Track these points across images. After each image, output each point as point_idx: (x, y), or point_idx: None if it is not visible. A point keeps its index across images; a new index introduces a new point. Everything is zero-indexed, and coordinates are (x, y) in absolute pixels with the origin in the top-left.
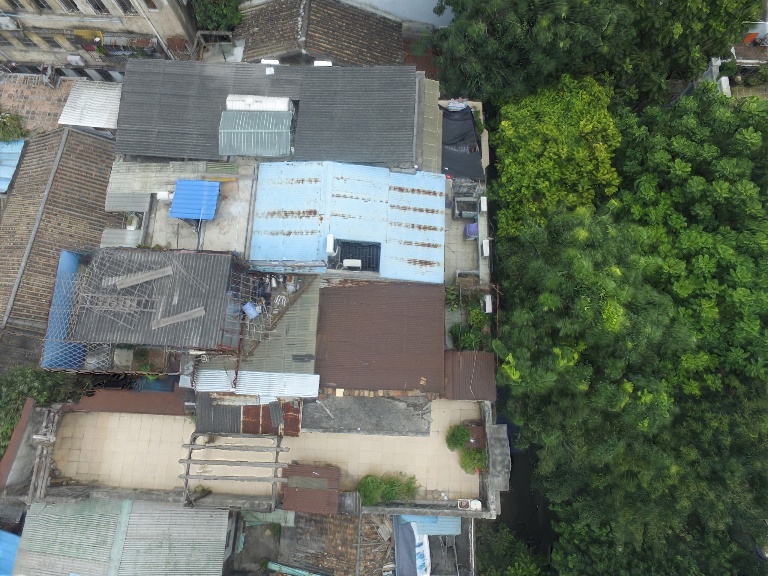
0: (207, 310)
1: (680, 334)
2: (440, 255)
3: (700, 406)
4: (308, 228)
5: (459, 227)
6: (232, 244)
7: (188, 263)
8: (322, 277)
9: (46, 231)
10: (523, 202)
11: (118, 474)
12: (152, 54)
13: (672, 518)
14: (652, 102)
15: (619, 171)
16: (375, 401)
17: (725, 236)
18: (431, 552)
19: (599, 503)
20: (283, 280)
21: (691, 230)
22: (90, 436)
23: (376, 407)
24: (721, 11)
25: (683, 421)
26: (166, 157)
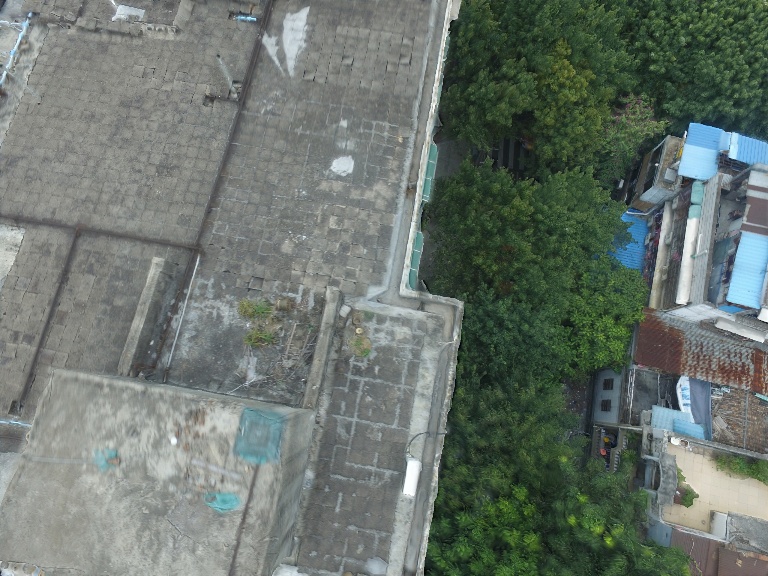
0: None
1: None
2: None
3: None
4: None
5: None
6: None
7: None
8: None
9: None
10: None
11: None
12: None
13: None
14: None
15: None
16: None
17: None
18: (660, 389)
19: None
20: None
21: None
22: None
23: None
24: None
25: None
26: None
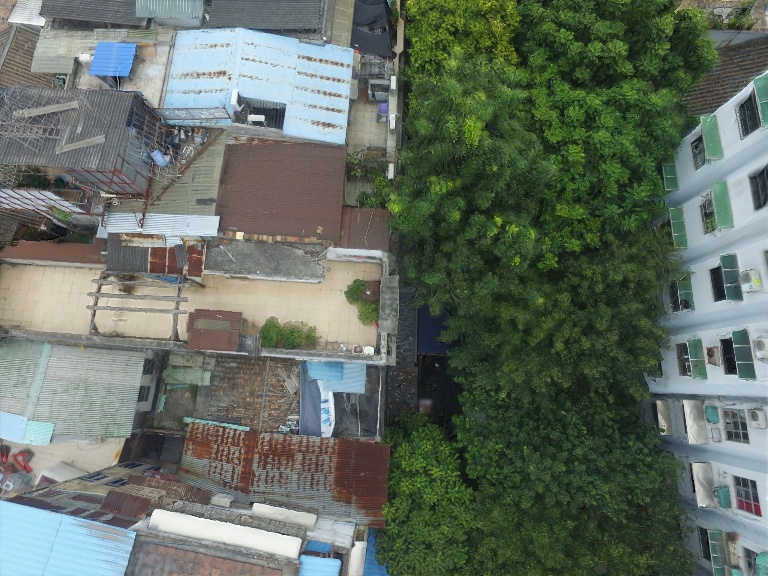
0: (107, 138)
1: (538, 164)
2: (343, 120)
3: (578, 261)
4: (217, 87)
5: (374, 110)
6: (147, 102)
7: (93, 99)
8: (230, 134)
9: None
10: None
11: (39, 321)
12: None
13: (552, 368)
14: None
15: (520, 54)
16: (275, 248)
17: (599, 95)
18: (341, 417)
19: (496, 368)
20: (191, 133)
21: None
22: (15, 287)
23: (276, 253)
24: None
25: (564, 278)
26: (91, 26)
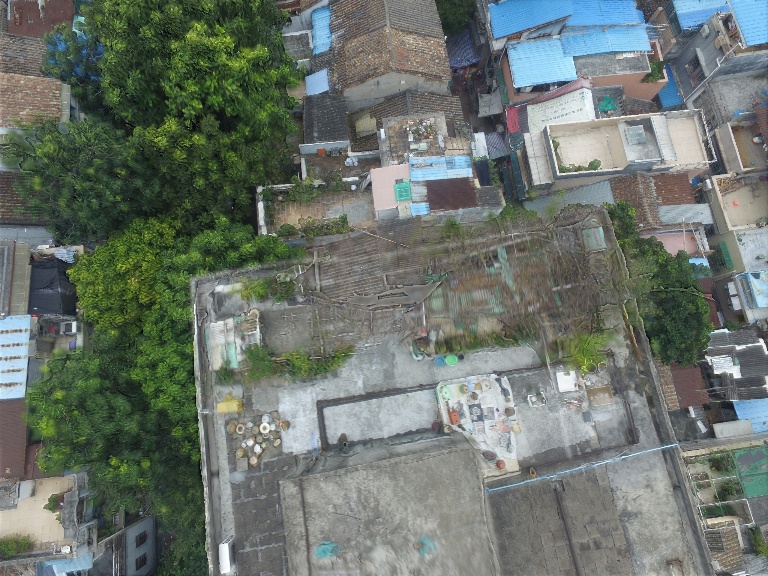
0: None
1: (117, 427)
2: (23, 376)
3: None
4: None
5: None
6: None
7: None
8: None
9: None
10: None
11: None
12: None
13: None
14: (234, 218)
15: None
16: None
17: None
18: None
19: None
20: None
21: (178, 339)
22: None
23: None
24: None
25: None
26: None
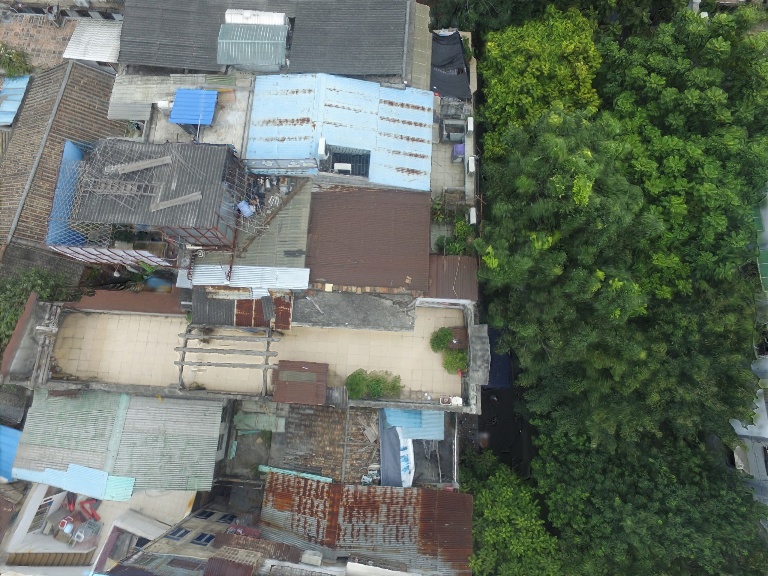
0: (204, 195)
1: (648, 219)
2: (427, 165)
3: (671, 309)
4: (301, 134)
5: (447, 150)
6: None
7: (186, 153)
8: (314, 182)
9: (50, 157)
10: (508, 124)
11: (116, 372)
12: None
13: (643, 417)
14: None
15: (600, 94)
16: (362, 299)
17: (696, 142)
18: (416, 462)
19: (576, 413)
20: (277, 182)
21: None
22: (90, 337)
23: (363, 304)
24: None
25: (655, 325)
26: (167, 70)
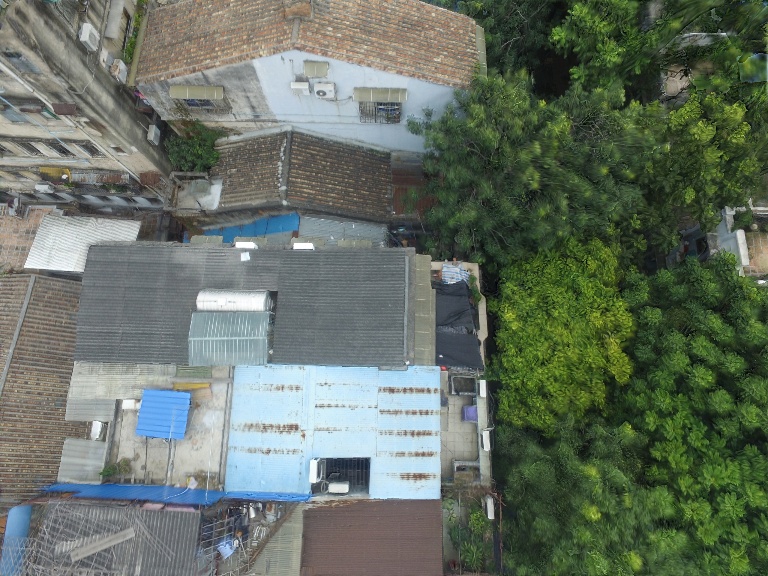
0: None
1: None
2: (436, 464)
3: None
4: (289, 446)
5: (456, 403)
6: (206, 462)
7: (152, 522)
8: None
9: (12, 392)
10: None
11: None
12: (125, 185)
13: None
14: None
15: (630, 351)
16: None
17: (752, 462)
18: None
19: None
20: (262, 508)
21: (713, 446)
22: None
23: None
24: (737, 173)
25: None
26: None
